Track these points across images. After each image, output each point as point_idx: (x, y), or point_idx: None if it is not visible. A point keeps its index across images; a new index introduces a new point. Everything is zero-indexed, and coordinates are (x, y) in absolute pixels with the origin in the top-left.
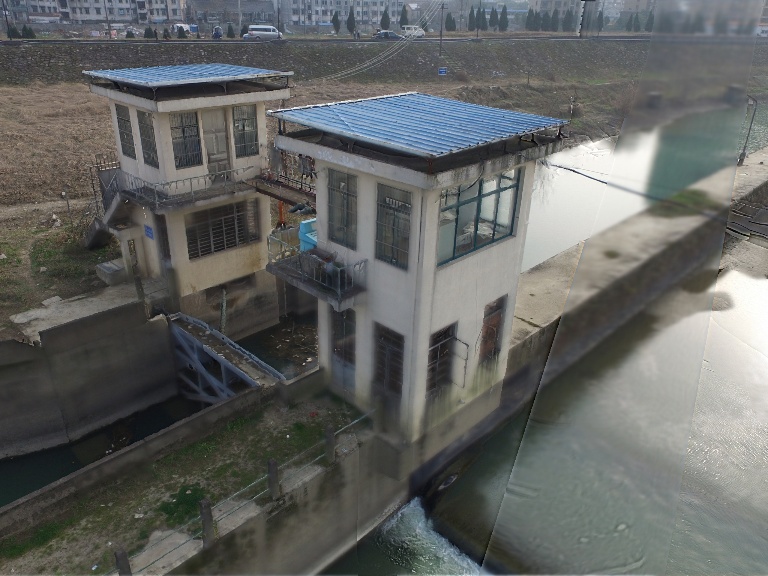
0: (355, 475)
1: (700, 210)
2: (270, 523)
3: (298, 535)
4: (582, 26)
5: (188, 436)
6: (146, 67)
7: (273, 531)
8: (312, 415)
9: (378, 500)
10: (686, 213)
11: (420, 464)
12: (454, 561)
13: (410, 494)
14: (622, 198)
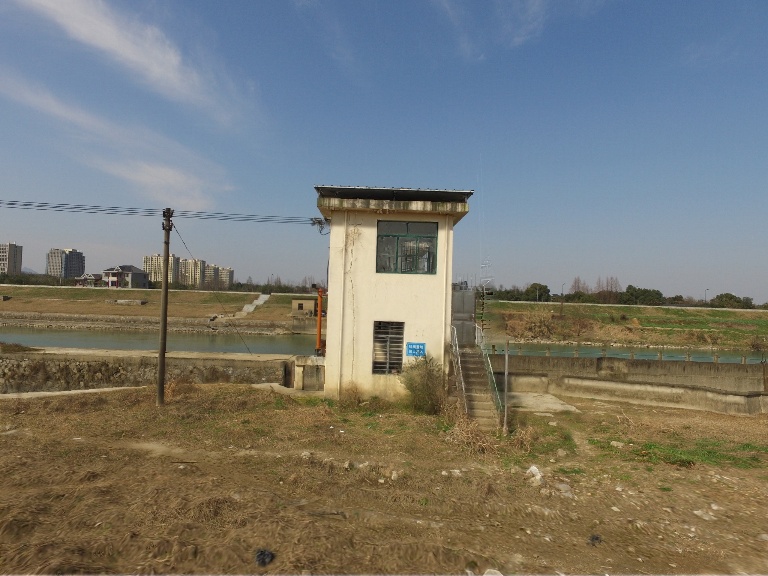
0: None
1: (480, 238)
2: None
3: None
4: None
5: None
6: None
7: None
8: None
9: None
10: (482, 238)
11: None
12: None
13: None
14: (487, 236)
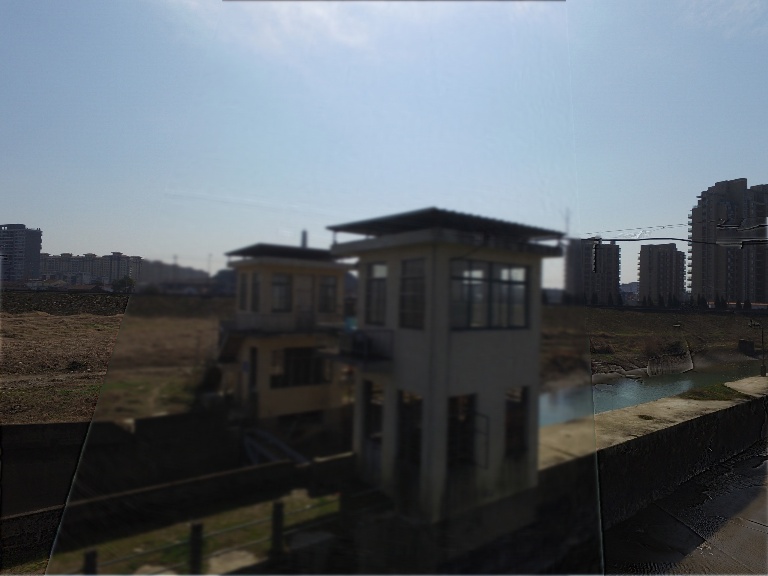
0: None
1: None
2: None
3: None
4: (595, 266)
5: None
6: None
7: None
8: None
9: None
10: None
11: None
12: None
13: None
14: None
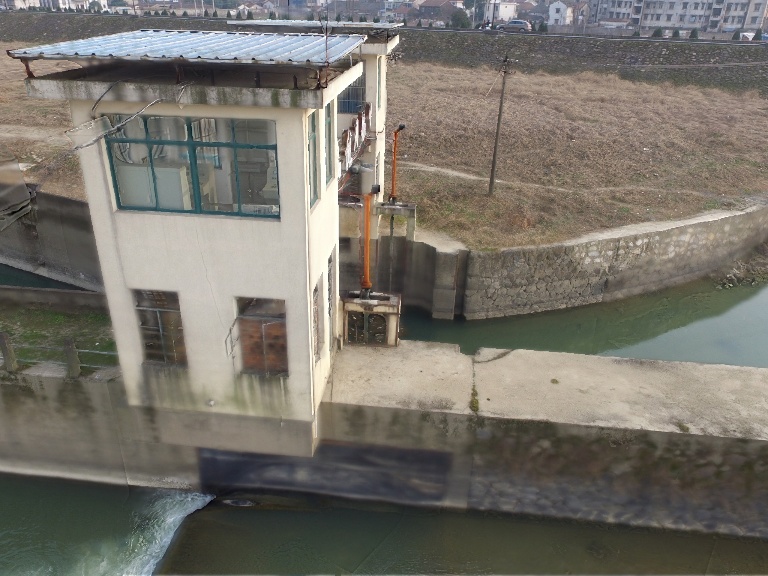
0: (108, 409)
1: None
2: (5, 389)
3: (44, 423)
4: None
5: (57, 304)
6: None
7: (11, 399)
8: None
9: (152, 459)
10: None
11: (156, 440)
12: (145, 564)
13: (203, 485)
14: None
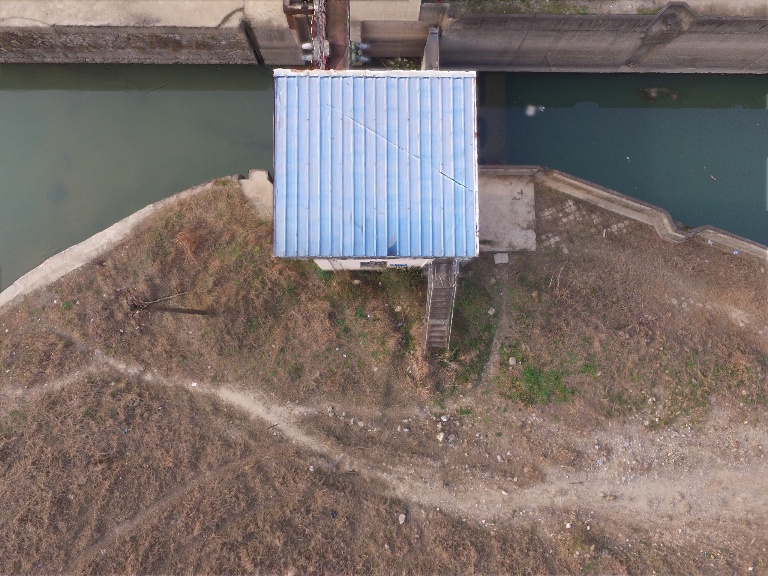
0: None
1: None
2: None
3: None
4: None
5: None
6: (391, 254)
7: None
8: (441, 0)
9: None
10: None
11: None
12: None
13: None
14: None
